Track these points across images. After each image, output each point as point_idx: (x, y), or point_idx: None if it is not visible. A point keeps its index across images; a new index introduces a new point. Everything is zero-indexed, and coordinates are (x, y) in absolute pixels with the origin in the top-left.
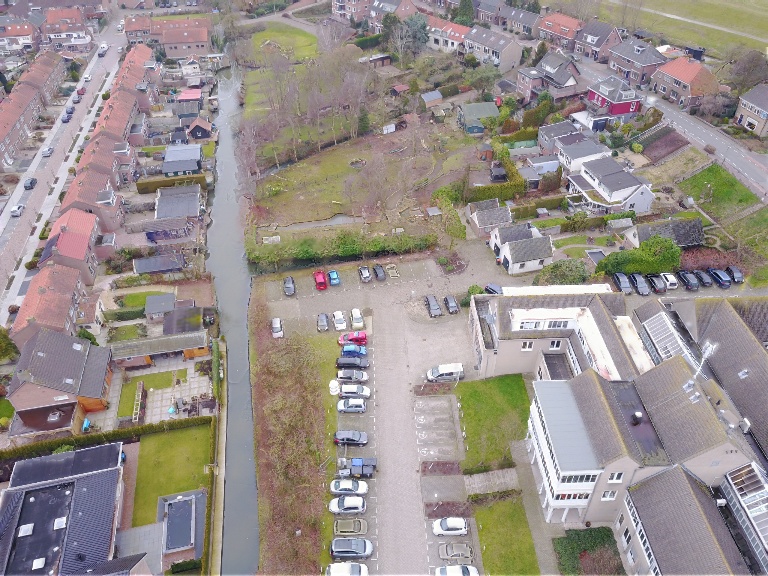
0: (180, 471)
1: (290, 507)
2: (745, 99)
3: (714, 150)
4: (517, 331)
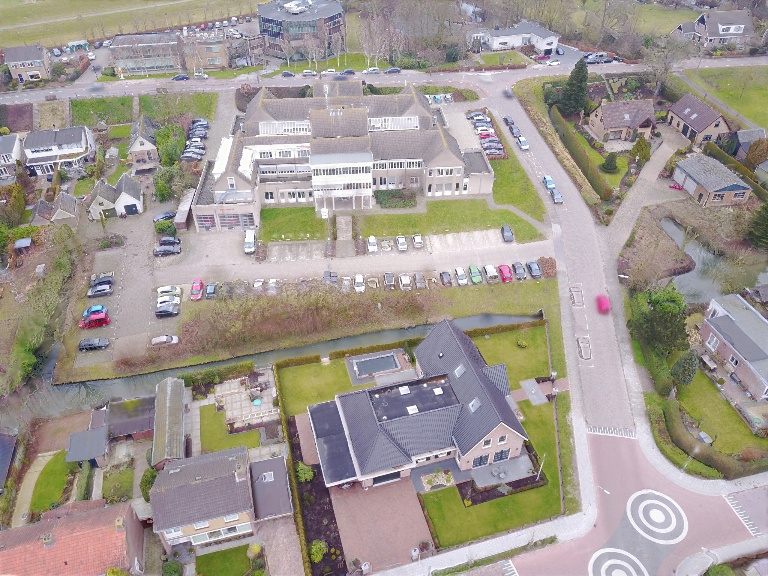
0: (328, 378)
1: (364, 305)
2: (12, 62)
3: (55, 96)
4: (251, 178)
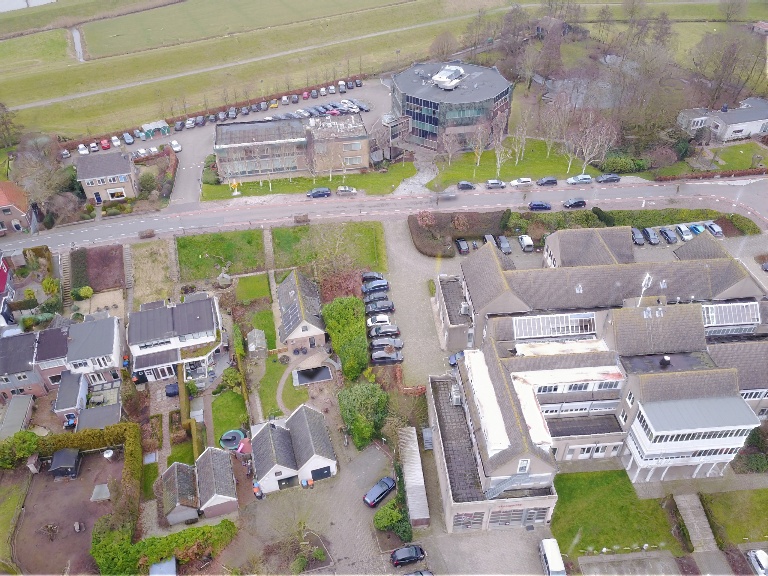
0: None
1: None
2: (87, 178)
3: (153, 231)
4: None
